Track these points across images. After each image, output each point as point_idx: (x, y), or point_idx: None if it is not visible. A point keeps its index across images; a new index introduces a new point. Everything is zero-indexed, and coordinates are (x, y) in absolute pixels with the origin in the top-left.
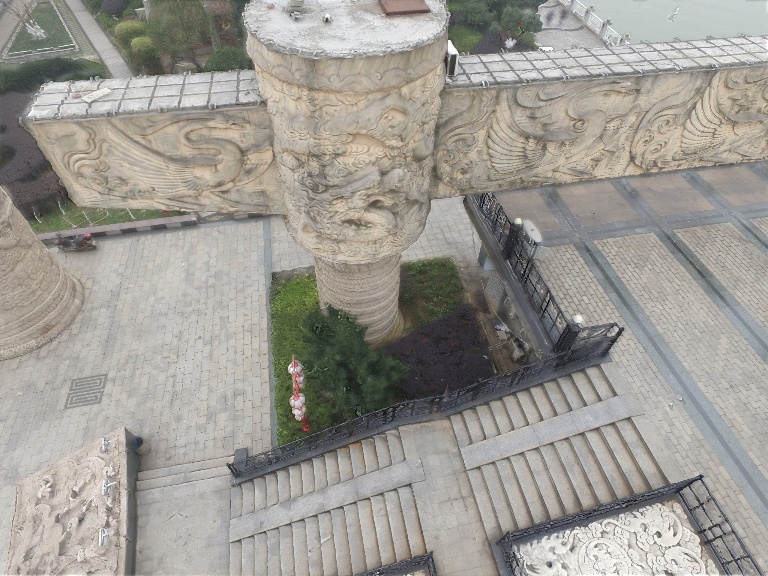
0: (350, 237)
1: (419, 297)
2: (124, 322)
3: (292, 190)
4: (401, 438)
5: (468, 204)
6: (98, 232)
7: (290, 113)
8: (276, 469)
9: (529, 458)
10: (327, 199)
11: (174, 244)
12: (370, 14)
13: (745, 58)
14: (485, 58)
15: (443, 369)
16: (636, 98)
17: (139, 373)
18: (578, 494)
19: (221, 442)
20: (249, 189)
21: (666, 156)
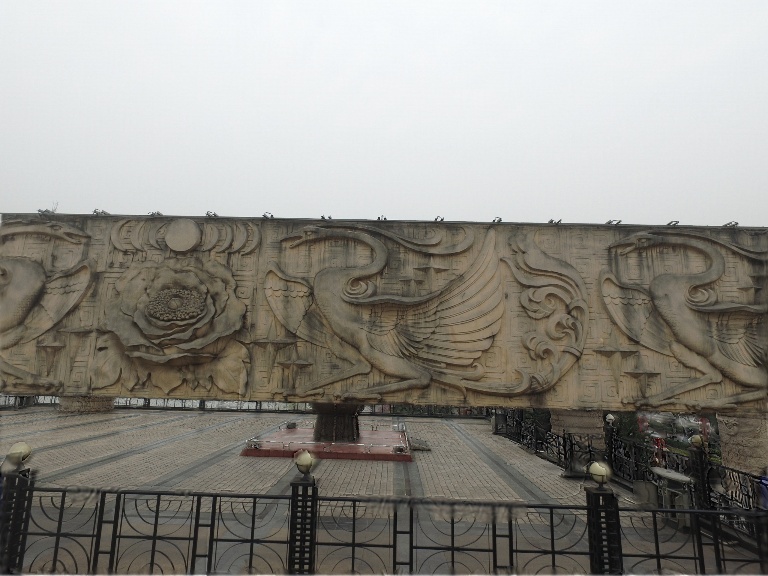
0: None
1: None
2: None
3: None
4: None
5: None
6: None
7: None
8: None
9: None
10: None
11: None
12: None
13: None
14: None
15: None
16: None
17: None
18: None
19: None
20: None
21: None
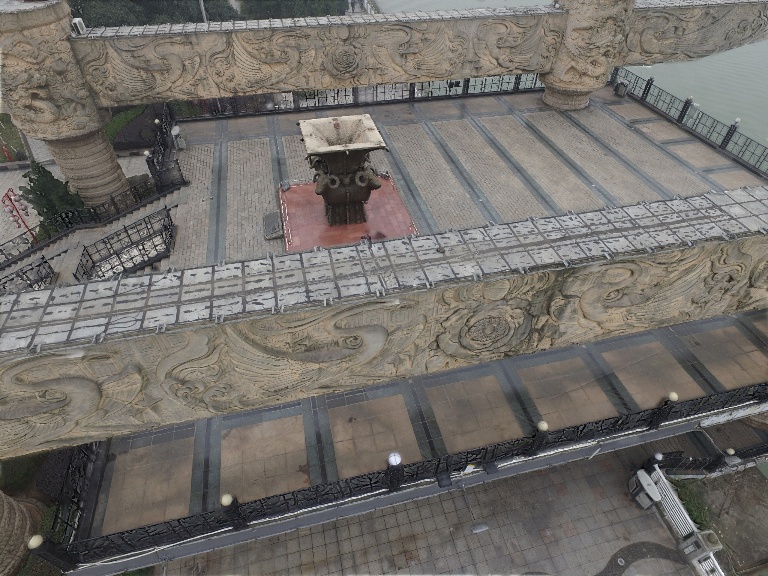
0: (34, 118)
1: None
2: None
3: None
4: None
5: None
6: None
7: None
8: (10, 262)
9: None
10: (4, 90)
11: (10, 177)
12: (17, 1)
13: None
14: (109, 28)
15: None
16: (193, 47)
17: None
18: None
19: None
20: None
21: (241, 85)
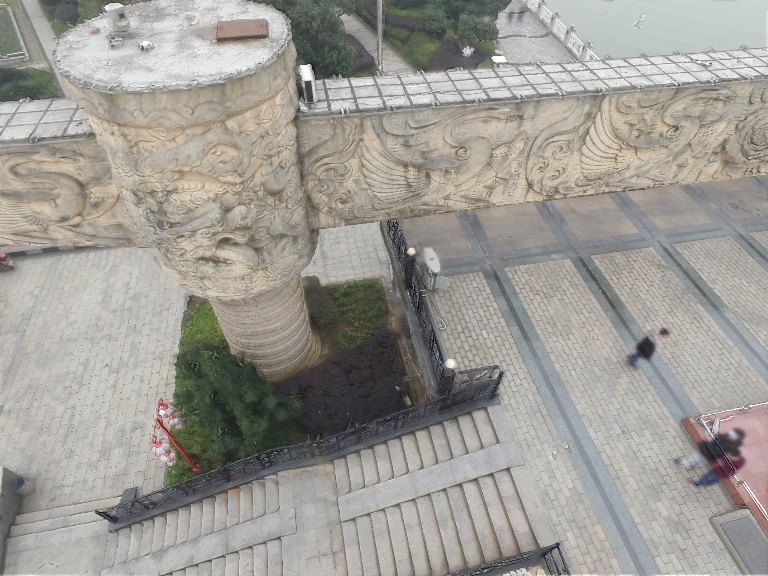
0: (210, 274)
1: (340, 322)
2: (30, 349)
3: (139, 226)
4: (278, 485)
5: (382, 227)
6: (17, 251)
7: (112, 148)
8: (153, 515)
9: (404, 510)
10: (167, 238)
11: (96, 264)
12: (200, 40)
13: (638, 81)
14: (356, 82)
15: (350, 402)
16: (520, 124)
17: (37, 404)
18: (446, 554)
19: (111, 481)
20: (103, 222)
21: (568, 182)
